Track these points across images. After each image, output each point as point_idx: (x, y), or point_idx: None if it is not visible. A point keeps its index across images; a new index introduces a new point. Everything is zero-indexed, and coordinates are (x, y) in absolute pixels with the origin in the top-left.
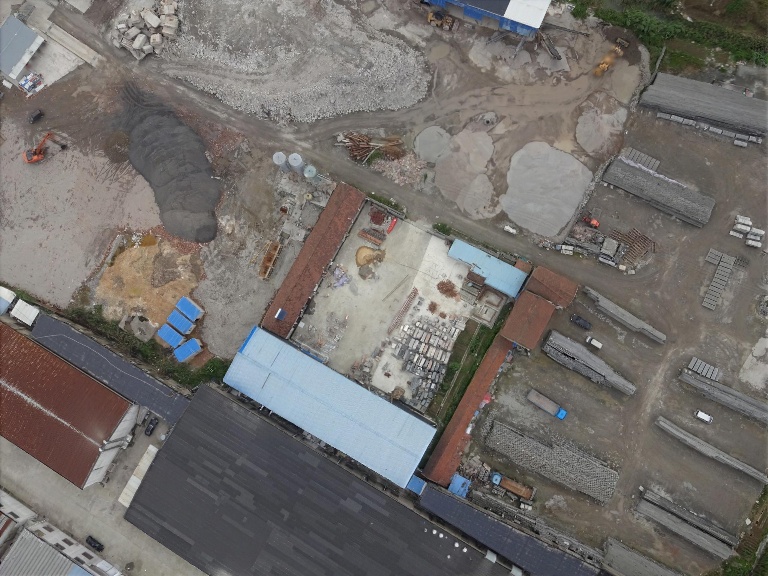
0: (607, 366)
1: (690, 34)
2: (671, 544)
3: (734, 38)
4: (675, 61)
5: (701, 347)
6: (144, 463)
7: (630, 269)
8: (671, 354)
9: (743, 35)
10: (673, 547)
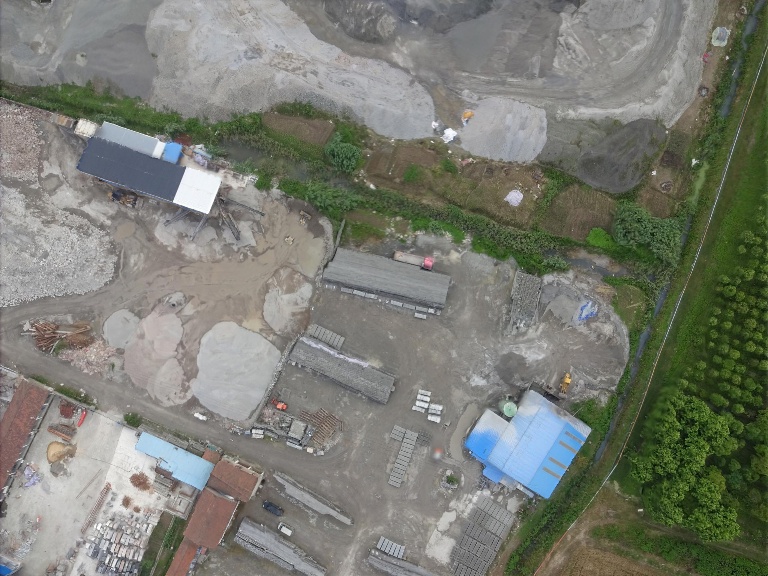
0: (295, 555)
1: (370, 204)
2: None
3: (413, 206)
4: (356, 233)
5: (389, 525)
6: None
7: (319, 450)
8: (361, 534)
9: (422, 202)
10: None
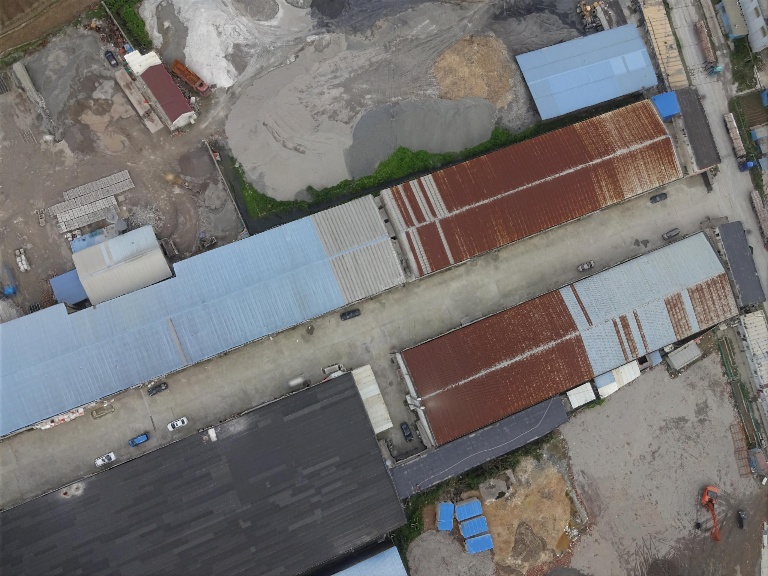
0: None
1: None
2: None
3: None
4: None
5: None
6: (382, 410)
7: None
8: None
9: None
10: None
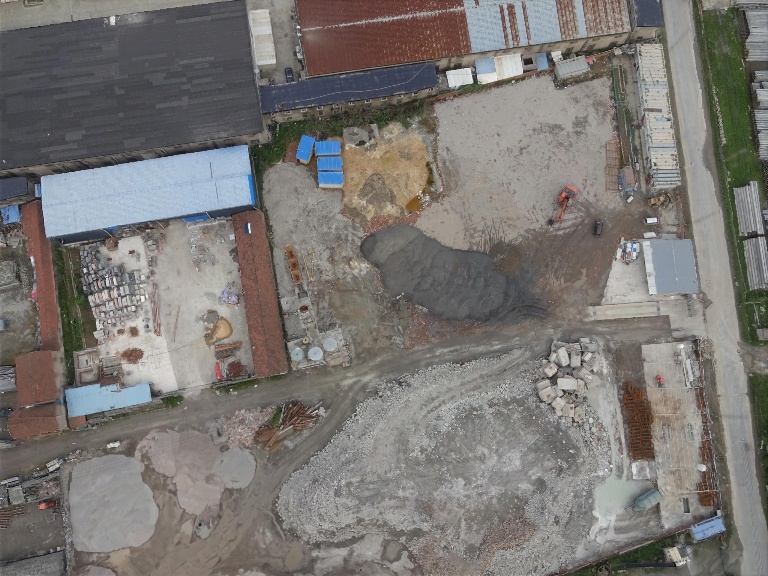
0: None
1: None
2: None
3: None
4: None
5: None
6: (270, 47)
7: None
8: None
9: None
10: None
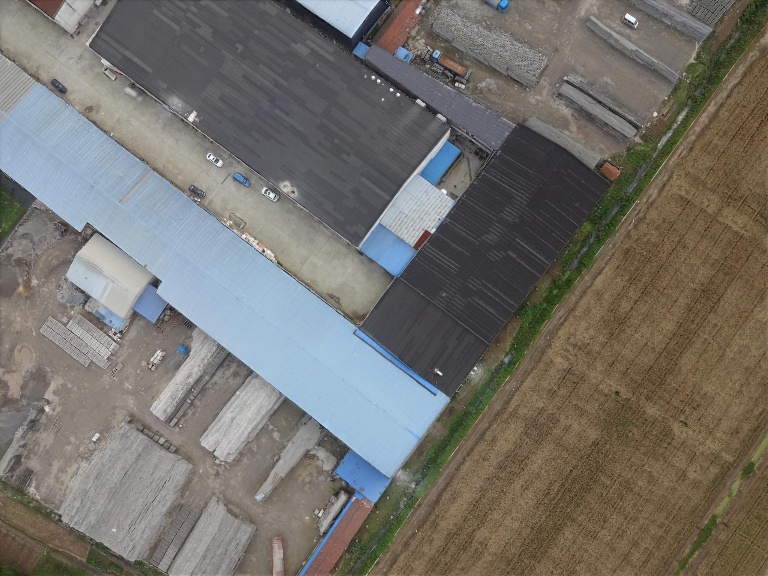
0: None
1: None
2: (584, 128)
3: None
4: None
5: None
6: None
7: None
8: None
9: None
10: (586, 131)
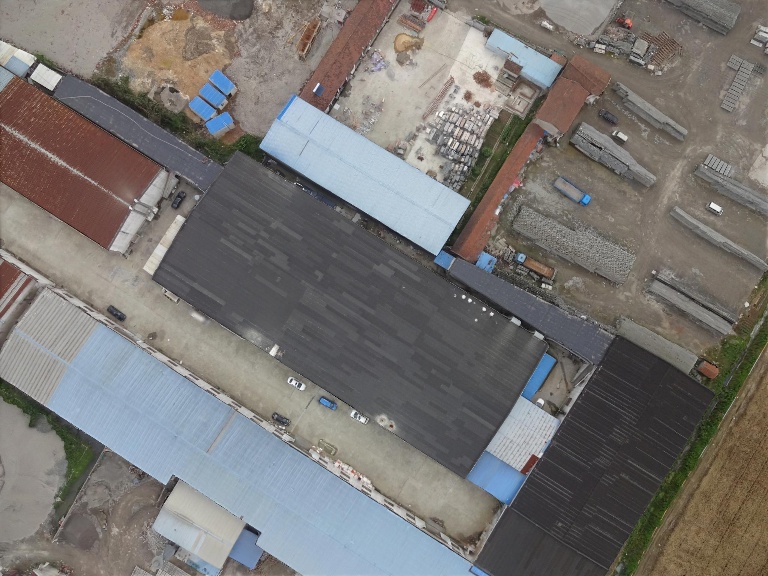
0: (631, 156)
1: None
2: (677, 323)
3: None
4: None
5: (717, 146)
6: (171, 232)
7: (657, 70)
8: (689, 151)
9: None
10: (679, 326)
